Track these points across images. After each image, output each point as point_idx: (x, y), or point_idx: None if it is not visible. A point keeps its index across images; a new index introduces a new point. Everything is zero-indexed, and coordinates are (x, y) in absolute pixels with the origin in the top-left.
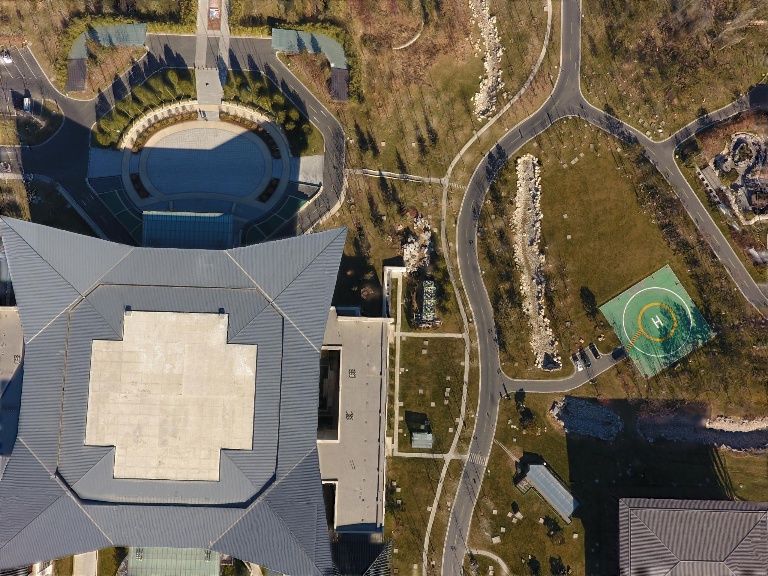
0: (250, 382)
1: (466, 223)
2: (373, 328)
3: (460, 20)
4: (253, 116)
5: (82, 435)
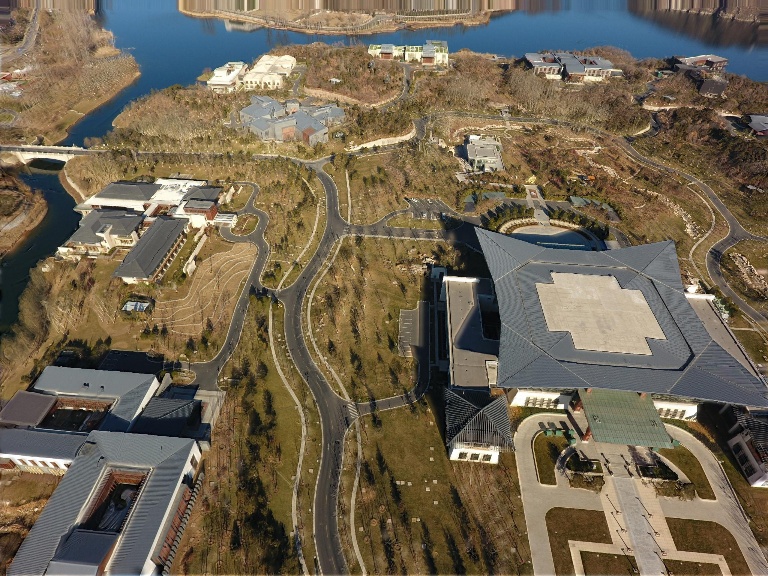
0: (647, 306)
1: (716, 278)
2: (701, 302)
3: (661, 204)
4: (569, 225)
5: (544, 326)
